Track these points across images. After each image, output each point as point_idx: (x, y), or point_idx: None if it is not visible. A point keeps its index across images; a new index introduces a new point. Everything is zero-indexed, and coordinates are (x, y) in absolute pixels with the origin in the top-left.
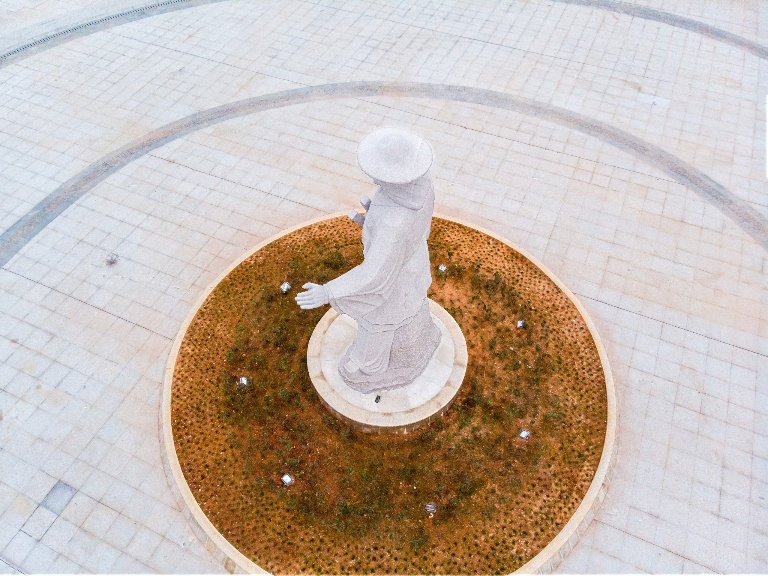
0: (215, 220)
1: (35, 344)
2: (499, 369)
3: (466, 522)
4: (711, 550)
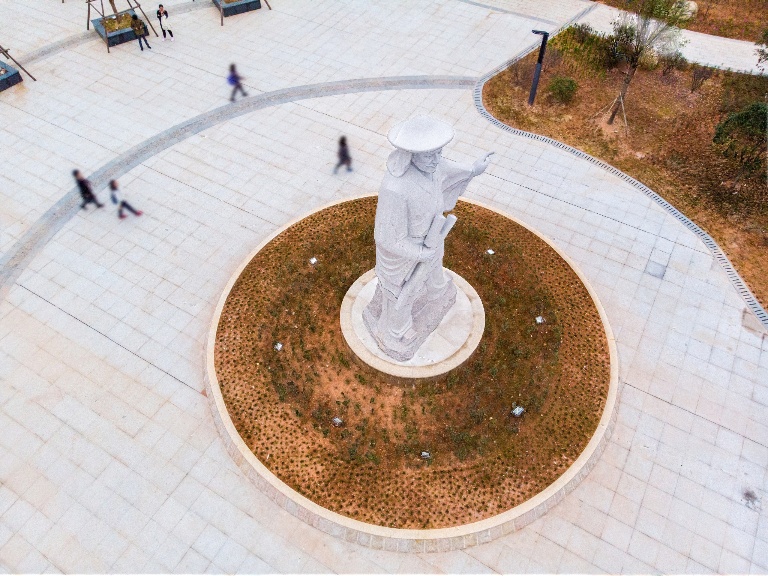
0: (642, 562)
1: (766, 392)
2: (315, 310)
3: (370, 223)
4: (221, 210)
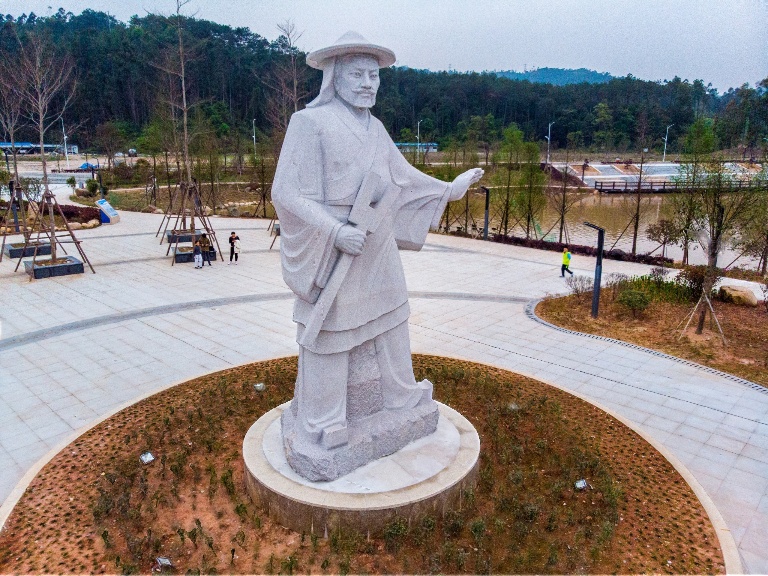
0: None
1: None
2: (228, 432)
3: None
4: (188, 353)
